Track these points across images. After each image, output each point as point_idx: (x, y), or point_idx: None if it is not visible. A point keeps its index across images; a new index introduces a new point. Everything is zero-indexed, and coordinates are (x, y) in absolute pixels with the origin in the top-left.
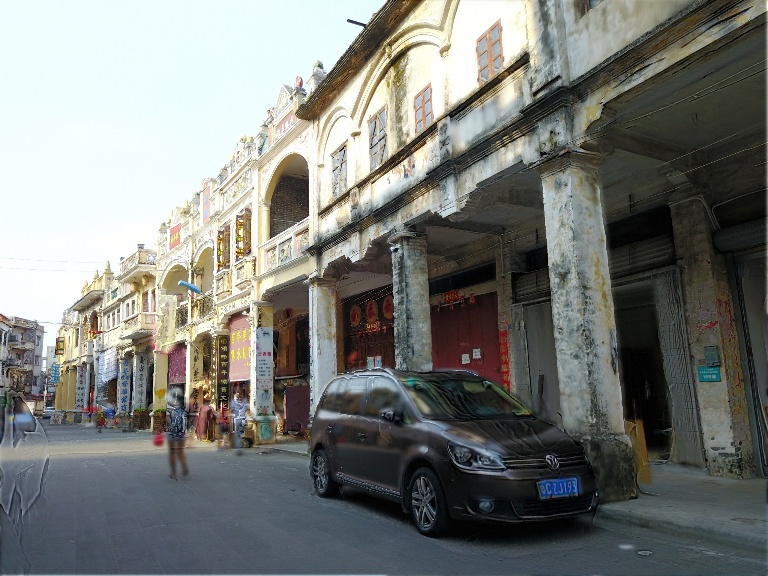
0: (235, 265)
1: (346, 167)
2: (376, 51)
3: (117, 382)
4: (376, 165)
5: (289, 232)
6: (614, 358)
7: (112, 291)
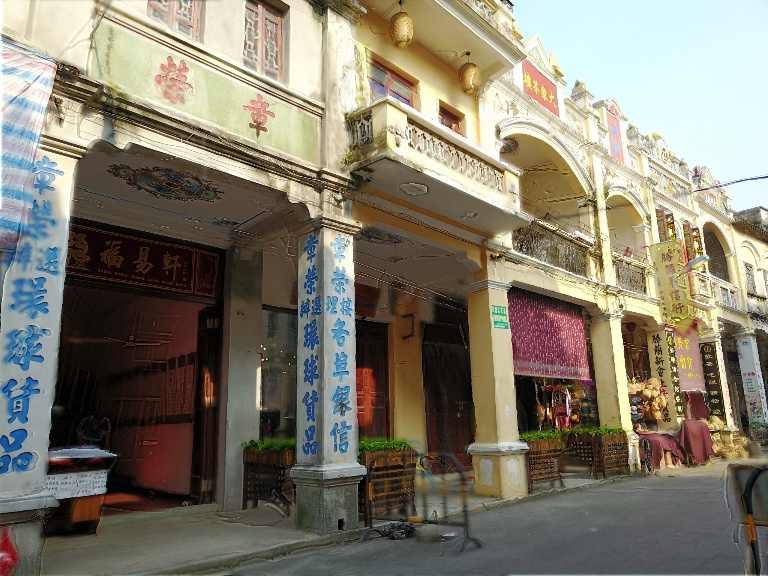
0: (699, 273)
1: (754, 280)
2: (767, 244)
3: (6, 277)
4: None
5: (728, 285)
6: None
7: None
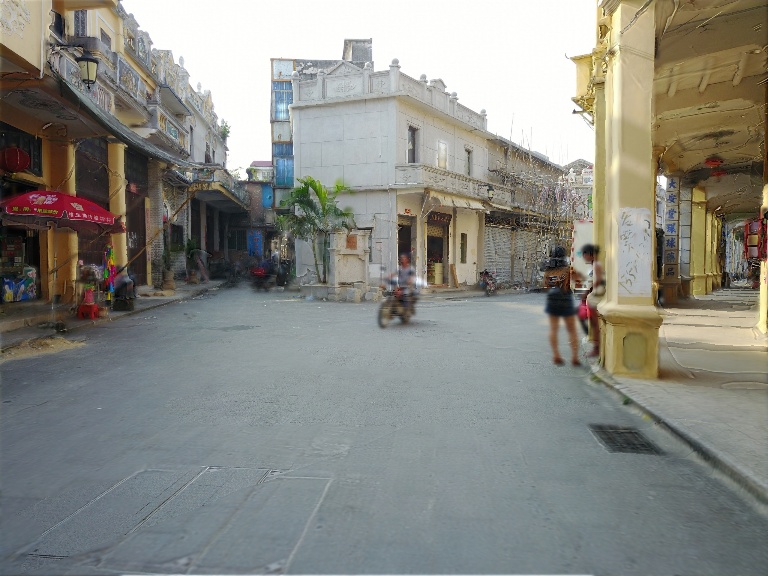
0: None
1: None
2: None
3: None
4: None
5: None
6: (741, 264)
7: None
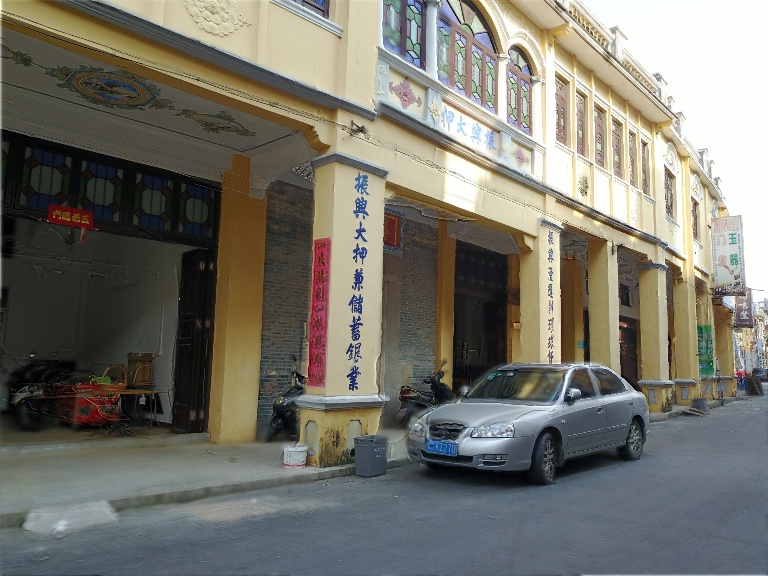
0: None
1: None
2: None
3: None
4: None
5: None
6: None
7: None
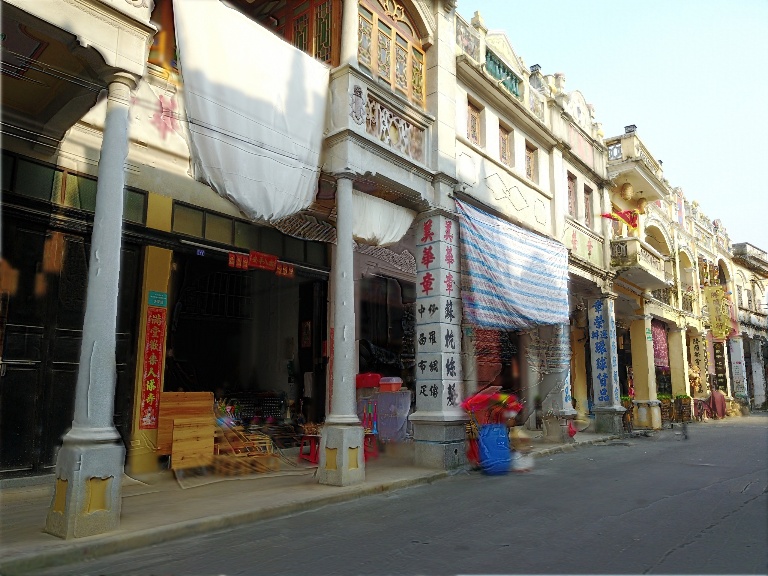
0: None
1: None
2: None
3: None
4: (750, 308)
5: None
6: None
7: (490, 50)
